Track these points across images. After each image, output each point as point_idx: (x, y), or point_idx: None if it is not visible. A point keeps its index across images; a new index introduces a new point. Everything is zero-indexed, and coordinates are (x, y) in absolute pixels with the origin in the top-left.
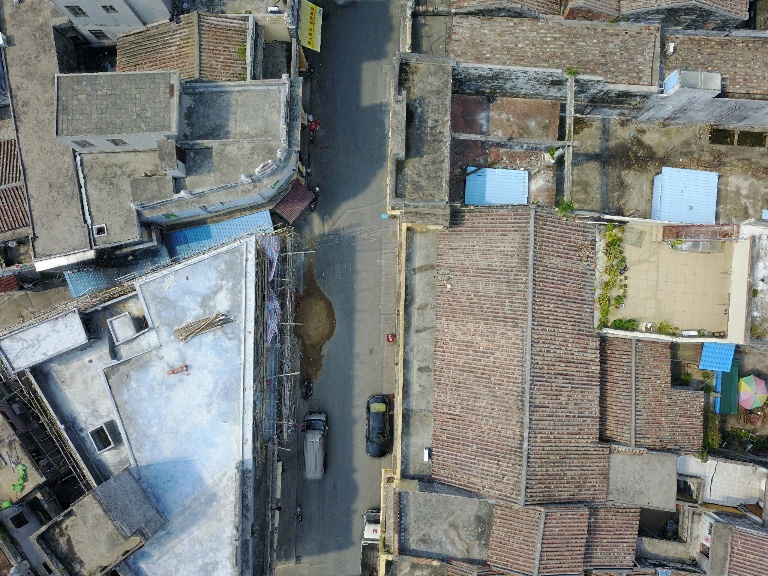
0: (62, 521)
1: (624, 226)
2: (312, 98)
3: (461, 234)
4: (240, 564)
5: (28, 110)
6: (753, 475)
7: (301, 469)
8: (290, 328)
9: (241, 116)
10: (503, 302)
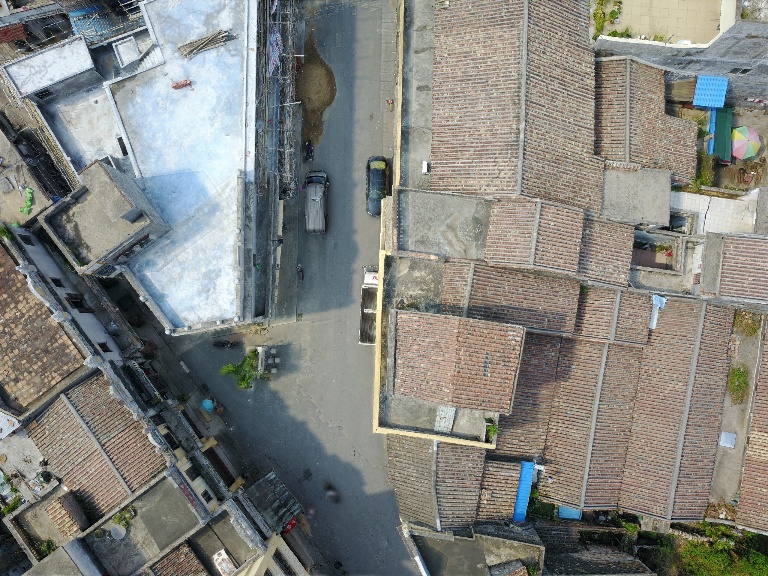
0: (69, 208)
1: None
2: None
3: None
4: (243, 271)
5: None
6: (746, 211)
7: (302, 230)
8: (292, 76)
9: None
10: (500, 6)
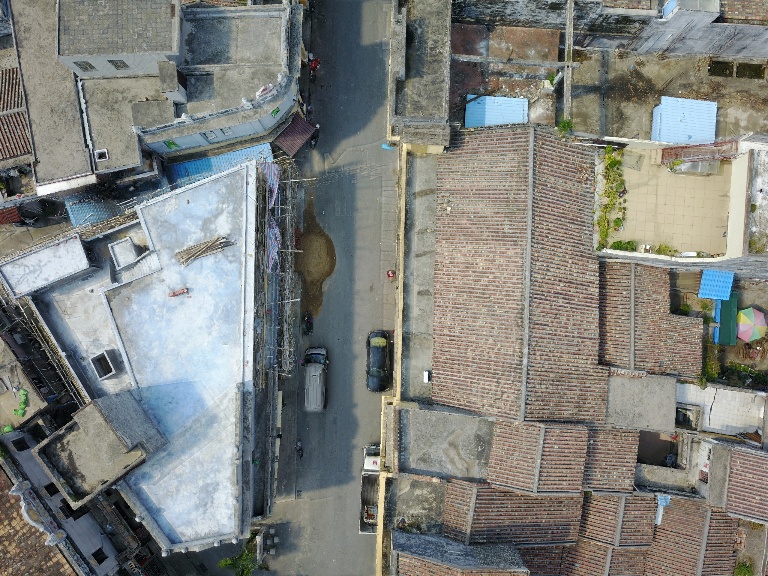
0: (64, 436)
1: (623, 150)
2: (312, 37)
3: (461, 157)
4: (241, 485)
5: (30, 36)
6: (752, 404)
7: (301, 405)
8: (290, 259)
9: (242, 42)
10: (503, 221)
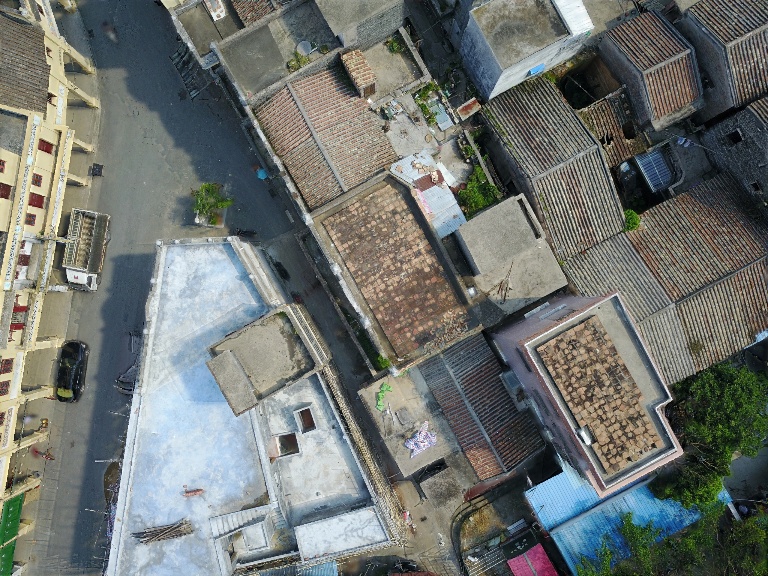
0: (297, 375)
1: None
2: None
3: None
4: None
5: None
6: None
7: None
8: None
9: None
10: None
